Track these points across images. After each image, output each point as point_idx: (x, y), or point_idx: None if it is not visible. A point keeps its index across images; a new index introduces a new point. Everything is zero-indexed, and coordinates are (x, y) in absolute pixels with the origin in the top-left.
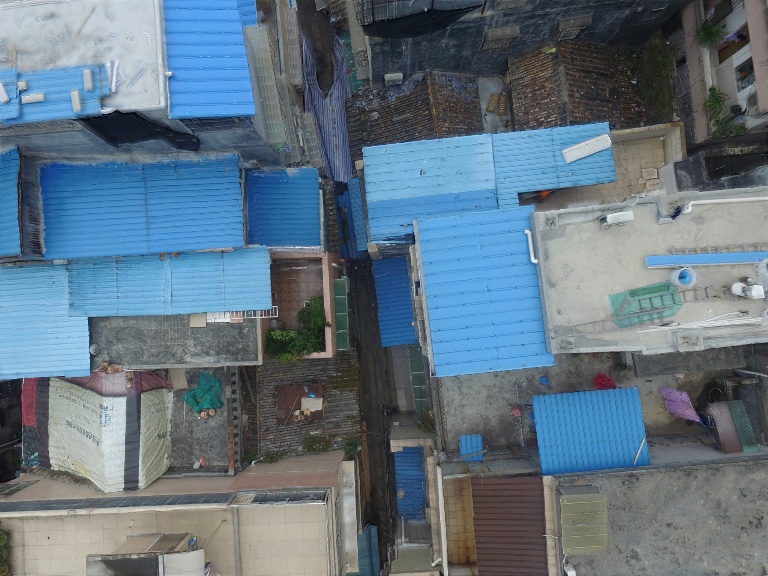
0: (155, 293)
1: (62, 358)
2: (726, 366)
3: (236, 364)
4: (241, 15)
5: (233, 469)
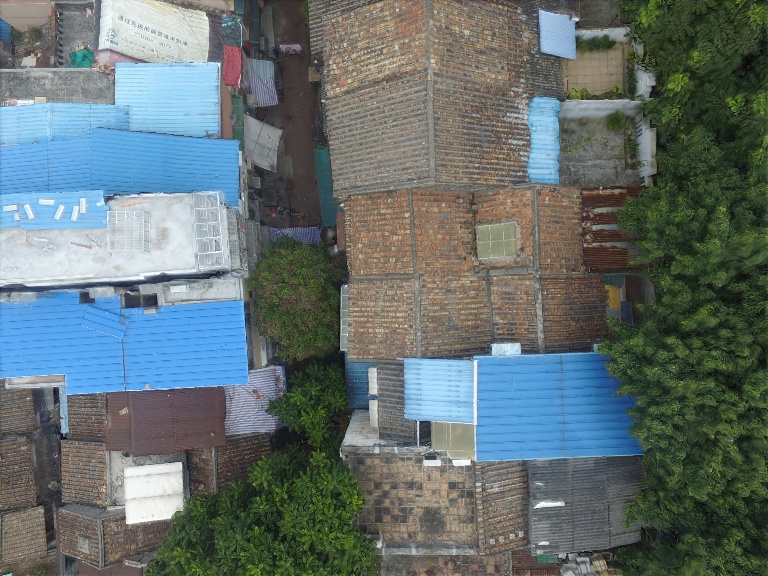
0: (60, 119)
1: (136, 76)
2: None
3: (13, 70)
4: (5, 330)
5: (51, 6)
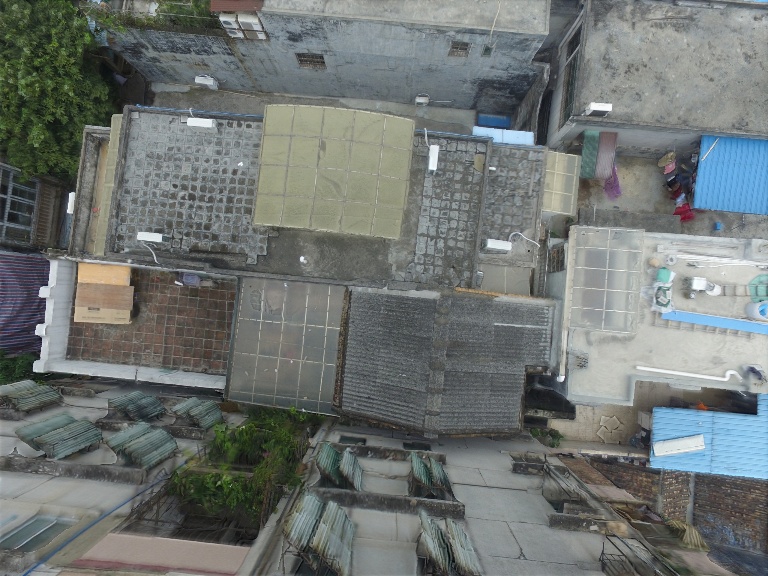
0: None
1: None
2: (599, 212)
3: None
4: None
5: None
